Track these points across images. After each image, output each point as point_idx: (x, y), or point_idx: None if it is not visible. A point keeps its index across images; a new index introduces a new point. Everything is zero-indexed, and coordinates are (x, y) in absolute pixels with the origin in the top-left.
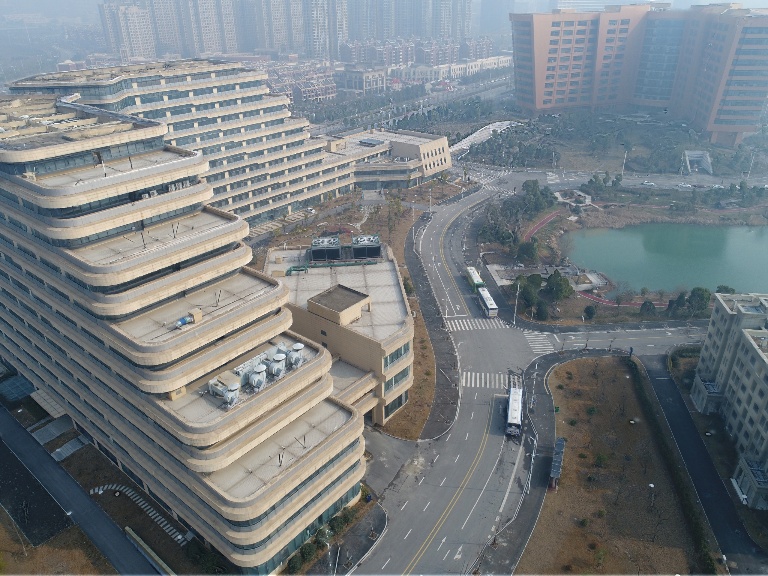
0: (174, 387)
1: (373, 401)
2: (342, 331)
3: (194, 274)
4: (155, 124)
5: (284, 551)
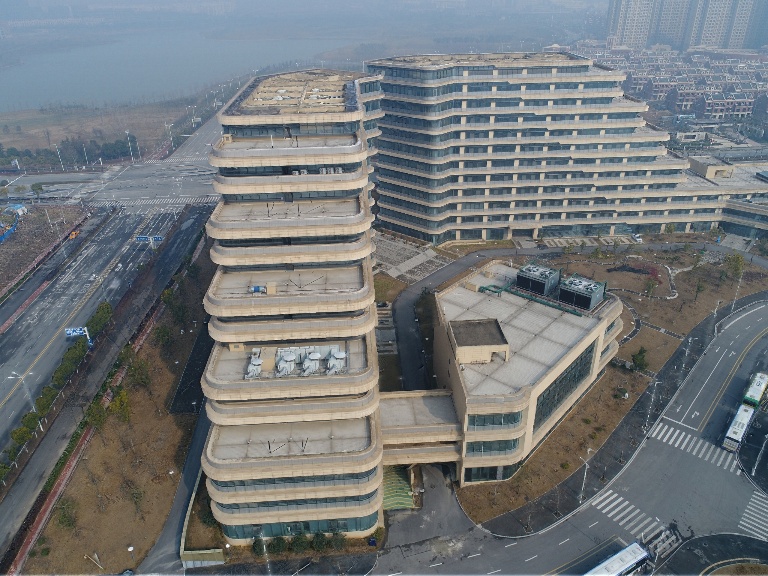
0: (223, 340)
1: (451, 455)
2: (455, 367)
3: (296, 252)
4: (354, 110)
5: (257, 529)
